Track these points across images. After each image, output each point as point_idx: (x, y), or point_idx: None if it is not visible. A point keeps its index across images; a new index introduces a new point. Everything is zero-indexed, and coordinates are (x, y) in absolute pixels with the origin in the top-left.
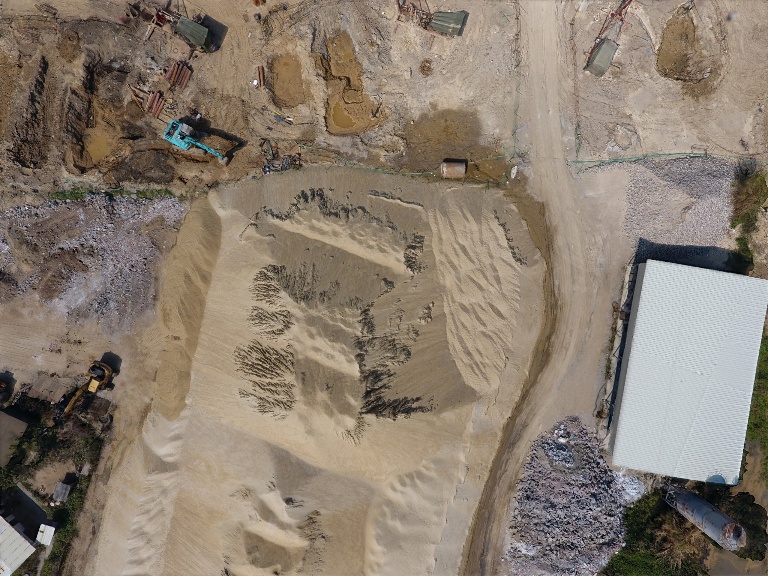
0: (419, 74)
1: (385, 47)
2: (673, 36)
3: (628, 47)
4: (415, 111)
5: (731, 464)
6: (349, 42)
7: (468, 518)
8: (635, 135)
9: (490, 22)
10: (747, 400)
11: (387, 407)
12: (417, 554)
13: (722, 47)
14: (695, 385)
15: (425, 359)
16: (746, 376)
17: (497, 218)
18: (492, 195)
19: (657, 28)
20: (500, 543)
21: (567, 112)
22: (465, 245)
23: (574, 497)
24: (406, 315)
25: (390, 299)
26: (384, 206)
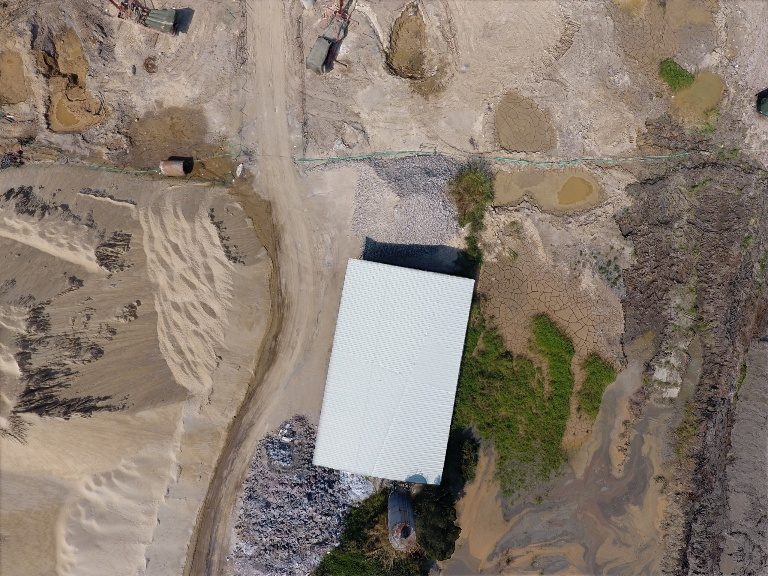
0: (144, 72)
1: (109, 44)
2: (408, 34)
3: (356, 45)
4: (140, 109)
5: (433, 464)
6: (77, 39)
7: (191, 518)
8: (361, 133)
9: (216, 19)
10: (450, 399)
11: (58, 406)
12: (123, 554)
13: (451, 45)
14: (394, 384)
15: (123, 358)
16: (448, 375)
17: (211, 216)
18: (214, 193)
19: (384, 26)
20: (226, 543)
21: (294, 110)
22: (178, 243)
23: (287, 497)
24: (98, 314)
25: (76, 297)
26: (90, 204)
